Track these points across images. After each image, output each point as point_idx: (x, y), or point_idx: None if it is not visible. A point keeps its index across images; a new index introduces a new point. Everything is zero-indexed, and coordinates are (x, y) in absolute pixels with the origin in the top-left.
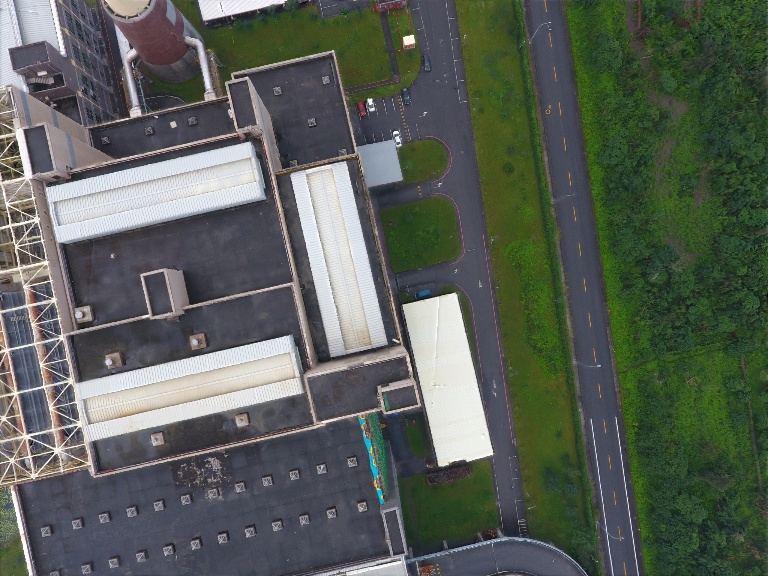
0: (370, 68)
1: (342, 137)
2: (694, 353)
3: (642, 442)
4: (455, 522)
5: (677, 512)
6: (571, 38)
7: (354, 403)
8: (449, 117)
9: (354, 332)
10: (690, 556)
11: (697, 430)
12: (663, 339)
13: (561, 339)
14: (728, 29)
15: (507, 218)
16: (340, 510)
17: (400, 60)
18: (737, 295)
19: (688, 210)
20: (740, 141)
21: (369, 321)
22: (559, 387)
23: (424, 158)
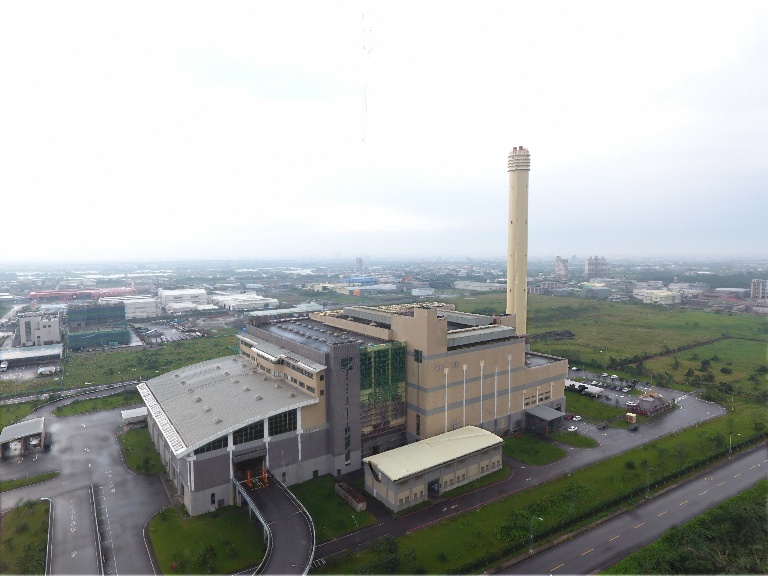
0: None
1: None
2: None
3: None
4: None
5: None
6: None
7: None
8: (619, 442)
9: None
10: None
11: None
12: None
13: None
14: None
15: (596, 476)
16: None
17: None
18: None
19: None
20: None
21: None
22: (493, 546)
23: (578, 439)
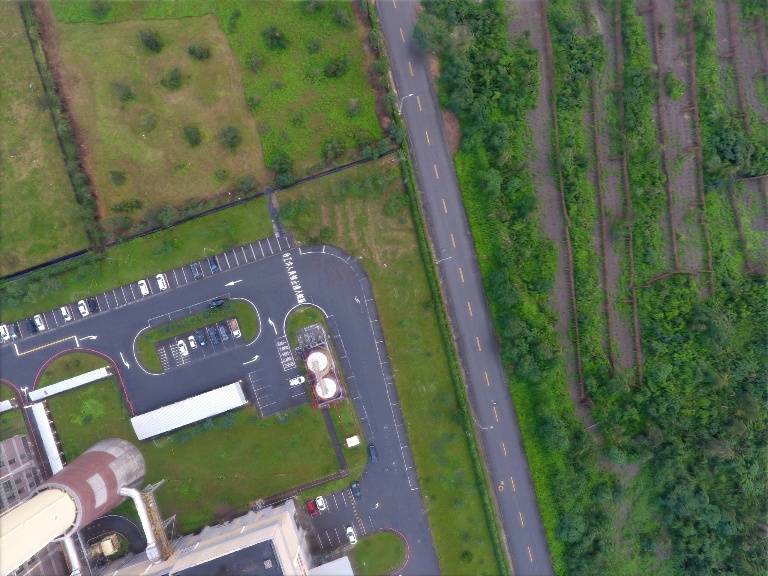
0: (316, 465)
1: None
2: None
3: None
4: None
5: None
6: (516, 412)
7: None
8: (402, 506)
9: None
10: None
11: None
12: None
13: None
14: (671, 398)
15: None
16: None
17: (346, 453)
18: None
19: (651, 569)
20: (695, 504)
21: None
22: None
23: (381, 552)
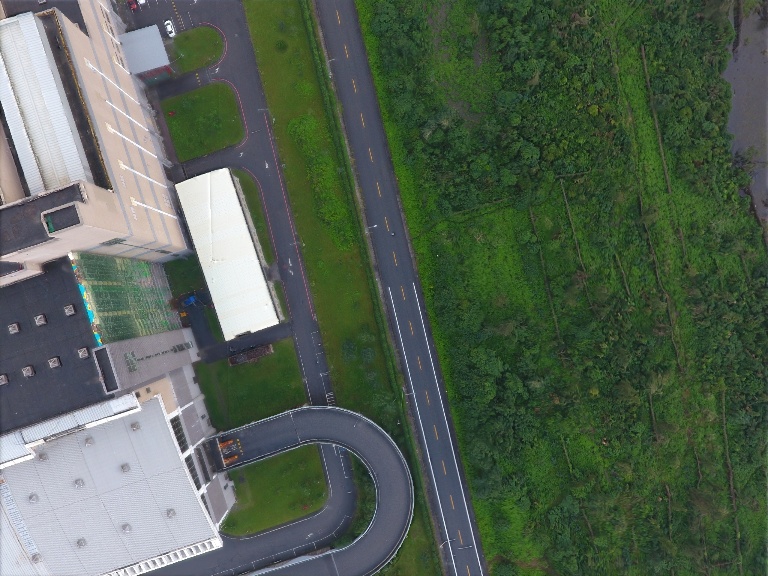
0: None
1: (73, 12)
2: (484, 211)
3: (436, 302)
4: (263, 402)
5: (474, 366)
6: None
7: (33, 236)
8: (220, 2)
9: (57, 181)
10: (489, 408)
11: (493, 287)
12: (449, 199)
13: (350, 210)
14: None
15: (285, 96)
16: (63, 359)
17: None
18: (514, 146)
19: (468, 72)
20: None
21: (68, 167)
22: (353, 258)
23: (199, 45)
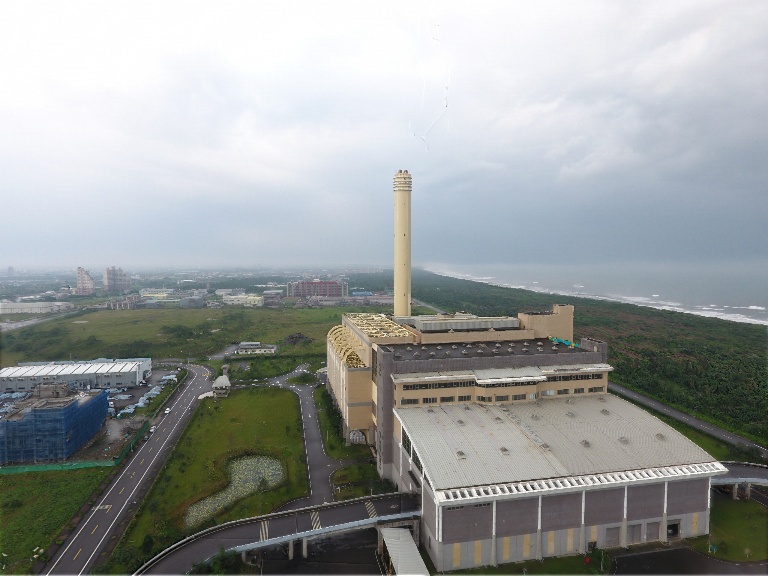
0: None
1: None
2: None
3: None
4: None
5: None
6: None
7: None
8: None
9: None
10: None
11: None
12: None
13: None
14: None
15: None
16: None
17: None
18: (762, 402)
19: None
20: None
21: None
22: None
23: None
